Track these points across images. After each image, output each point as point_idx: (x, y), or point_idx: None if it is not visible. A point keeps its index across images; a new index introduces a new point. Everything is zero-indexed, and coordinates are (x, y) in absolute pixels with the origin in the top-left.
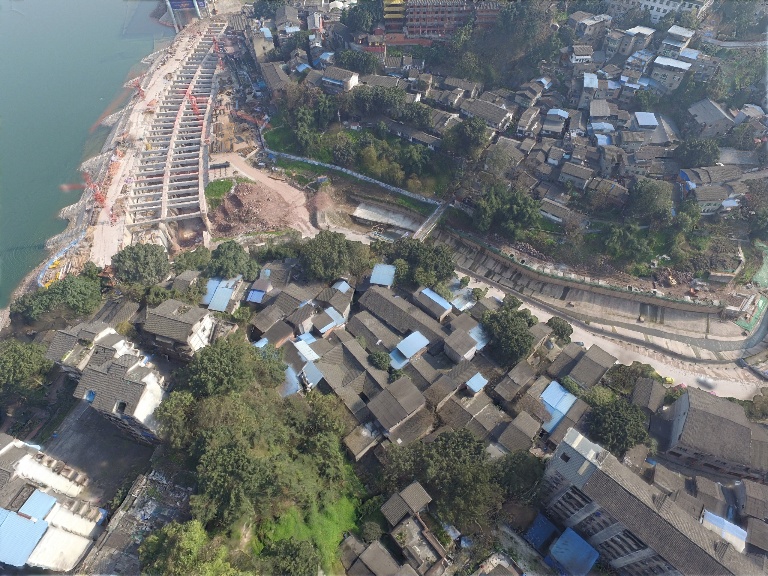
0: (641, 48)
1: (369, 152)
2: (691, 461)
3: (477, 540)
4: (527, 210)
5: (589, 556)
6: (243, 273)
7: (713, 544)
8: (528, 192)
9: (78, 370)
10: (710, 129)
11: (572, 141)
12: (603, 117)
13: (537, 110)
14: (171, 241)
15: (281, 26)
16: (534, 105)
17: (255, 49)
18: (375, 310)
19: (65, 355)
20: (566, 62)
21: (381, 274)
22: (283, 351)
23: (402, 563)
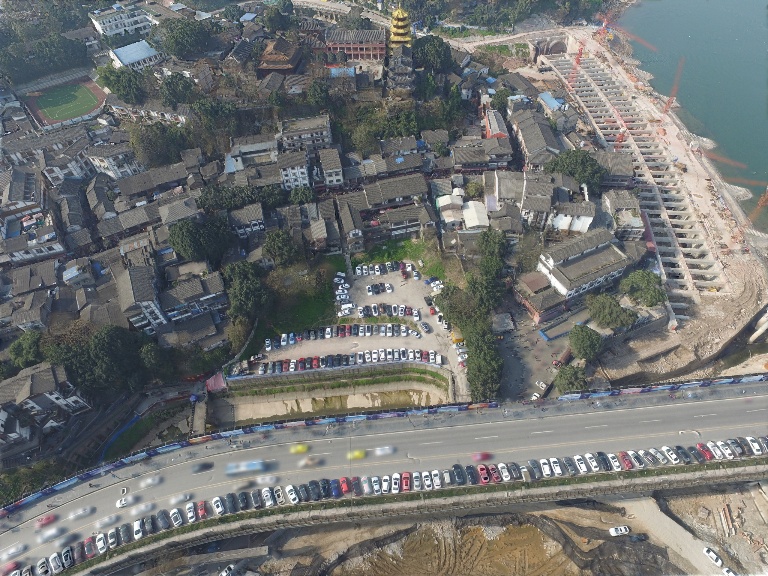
0: None
1: None
2: None
3: None
4: None
5: None
6: None
7: None
8: None
9: None
10: None
11: None
12: None
13: None
14: None
15: None
16: None
17: None
18: None
19: None
20: None
21: None
22: None
23: None
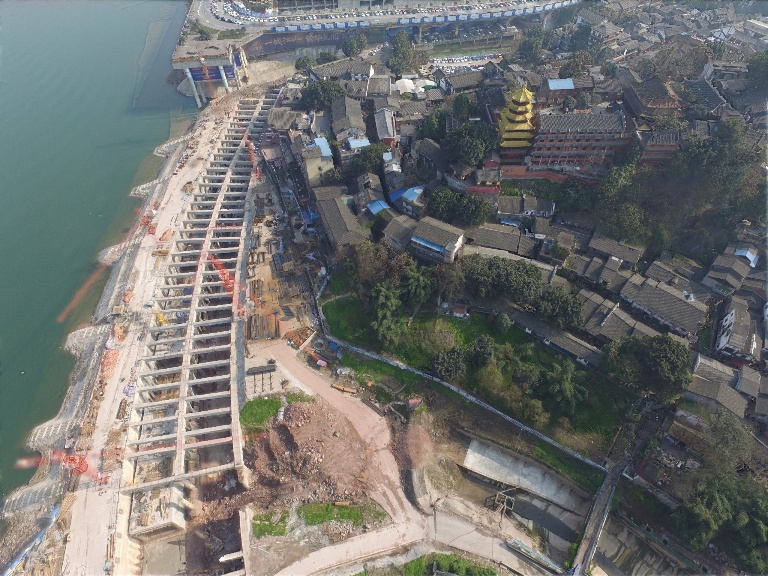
0: None
1: (492, 375)
2: None
3: None
4: None
5: None
6: None
7: None
8: (762, 474)
9: None
10: None
11: None
12: None
13: (746, 307)
14: (189, 506)
15: (342, 133)
16: (734, 291)
17: (308, 170)
18: None
19: None
20: None
21: None
22: None
23: None
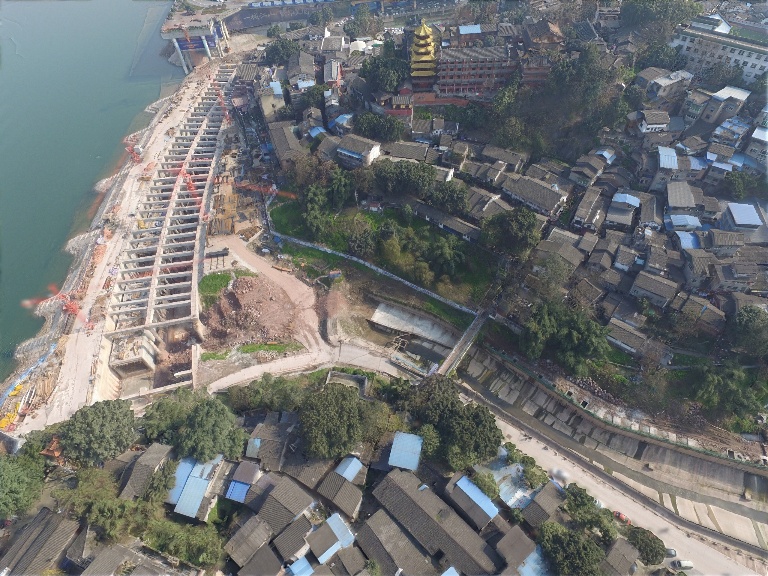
0: (731, 115)
1: (391, 246)
2: None
3: None
4: (592, 341)
5: None
6: (224, 453)
7: None
8: (590, 307)
9: None
10: None
11: (646, 241)
12: (685, 207)
13: (598, 193)
14: (157, 350)
15: (294, 78)
16: (593, 184)
17: (263, 107)
18: (394, 511)
19: None
20: (634, 130)
21: (403, 451)
22: None
23: None
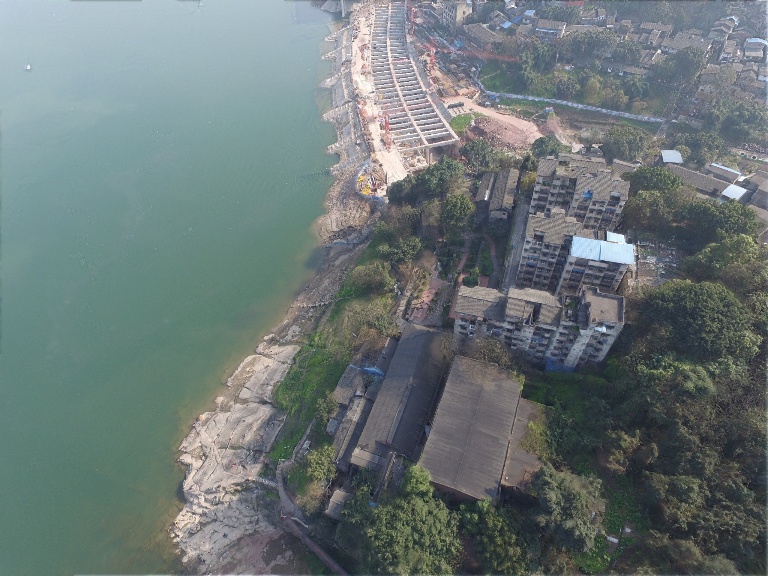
0: None
1: (594, 83)
2: None
3: None
4: (759, 113)
5: None
6: None
7: None
8: None
9: (565, 181)
10: None
11: None
12: None
13: None
14: None
15: None
16: (727, 39)
17: (457, 14)
18: None
19: (557, 170)
20: (752, 1)
21: (670, 156)
22: None
23: None
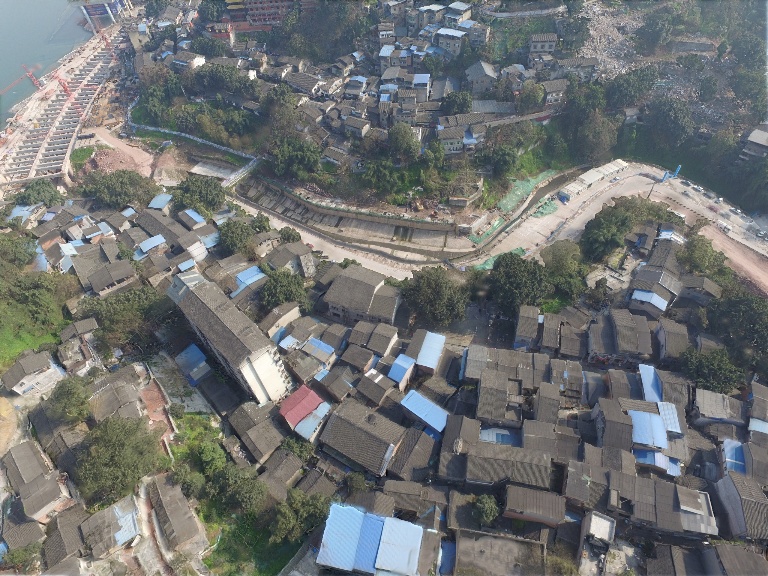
0: (434, 22)
1: (201, 118)
2: (344, 318)
3: (135, 358)
4: (306, 154)
5: (199, 359)
6: (44, 201)
7: (243, 328)
8: (321, 143)
9: None
10: (478, 85)
11: (361, 100)
12: (391, 80)
13: (346, 78)
14: None
15: None
16: (348, 75)
17: (132, 42)
18: (144, 226)
19: None
20: (375, 38)
21: (158, 201)
22: (51, 250)
23: (58, 363)
